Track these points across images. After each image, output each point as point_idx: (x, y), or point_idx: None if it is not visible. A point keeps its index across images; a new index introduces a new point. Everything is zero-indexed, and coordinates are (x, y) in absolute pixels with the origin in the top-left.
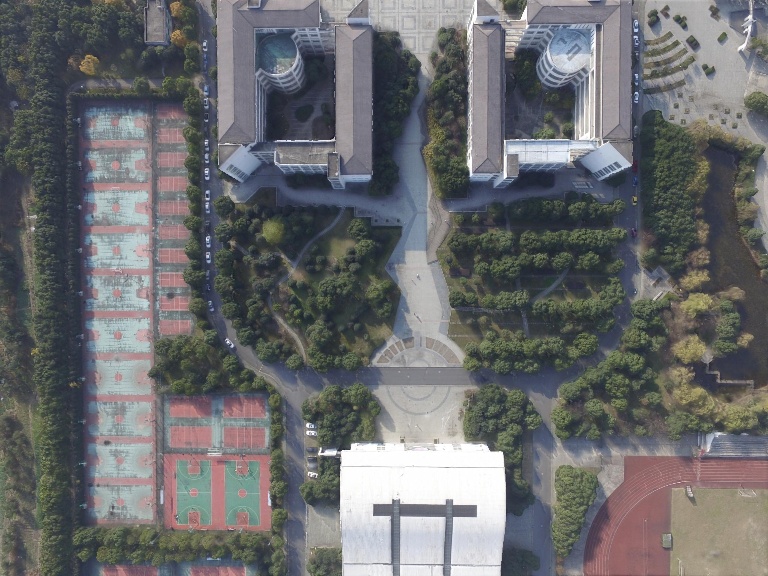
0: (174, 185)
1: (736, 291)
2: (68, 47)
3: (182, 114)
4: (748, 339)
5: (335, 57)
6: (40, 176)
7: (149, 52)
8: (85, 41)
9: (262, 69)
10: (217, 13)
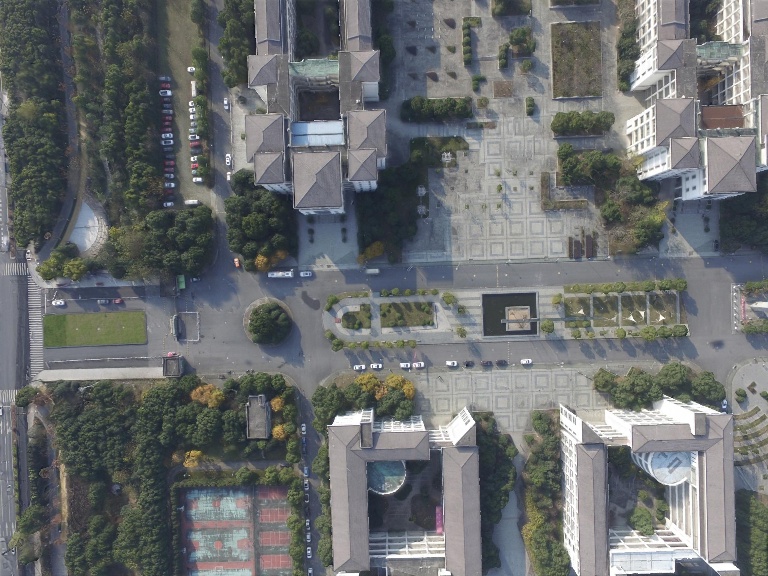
0: (277, 563)
1: None
2: (171, 443)
3: (282, 495)
4: None
5: (443, 477)
6: (149, 575)
7: (252, 448)
8: (189, 441)
9: (371, 488)
10: (329, 448)
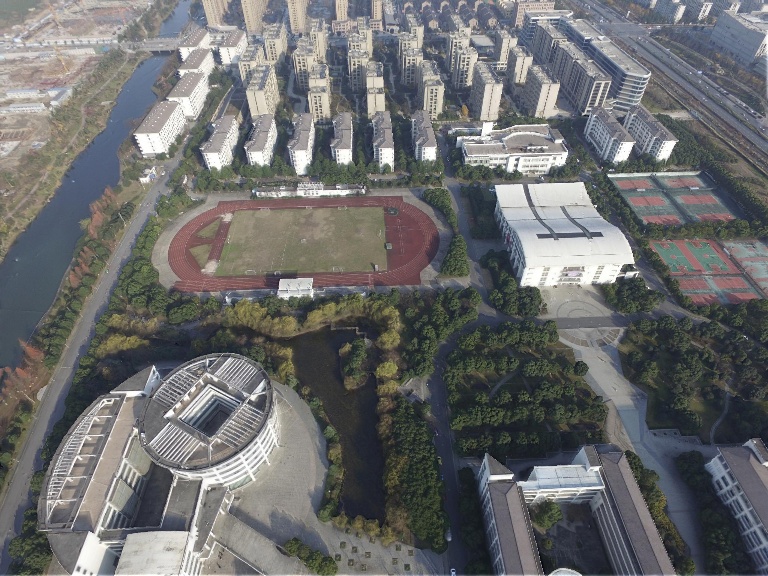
0: None
1: (350, 383)
2: None
3: None
4: (346, 347)
5: None
6: None
7: None
8: None
9: None
10: None
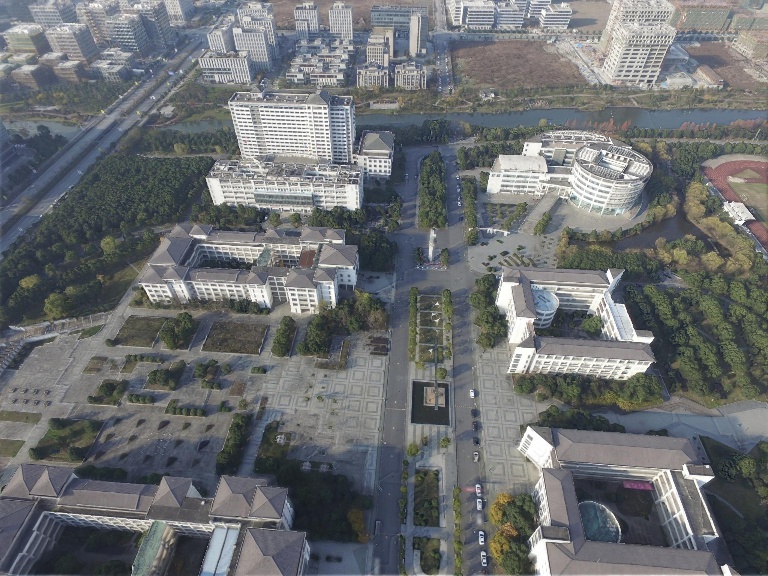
0: None
1: (660, 241)
2: None
3: None
4: (692, 236)
5: (588, 463)
6: None
7: None
8: None
9: None
10: None
